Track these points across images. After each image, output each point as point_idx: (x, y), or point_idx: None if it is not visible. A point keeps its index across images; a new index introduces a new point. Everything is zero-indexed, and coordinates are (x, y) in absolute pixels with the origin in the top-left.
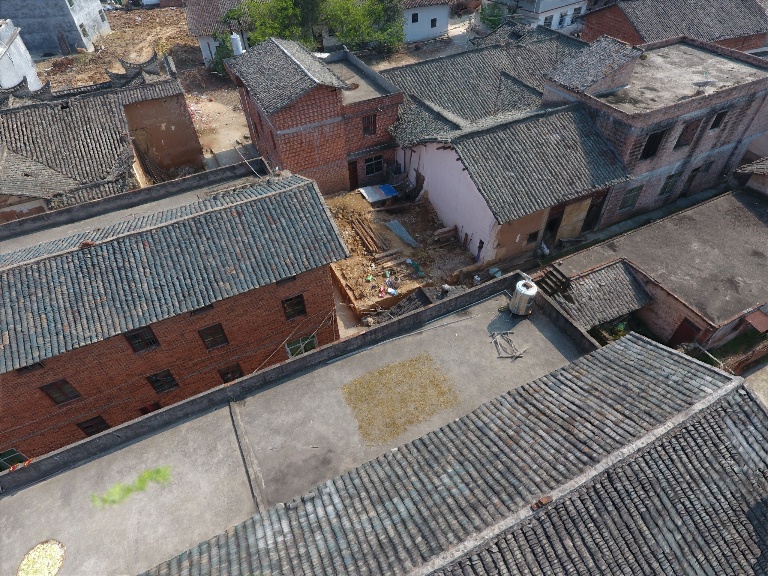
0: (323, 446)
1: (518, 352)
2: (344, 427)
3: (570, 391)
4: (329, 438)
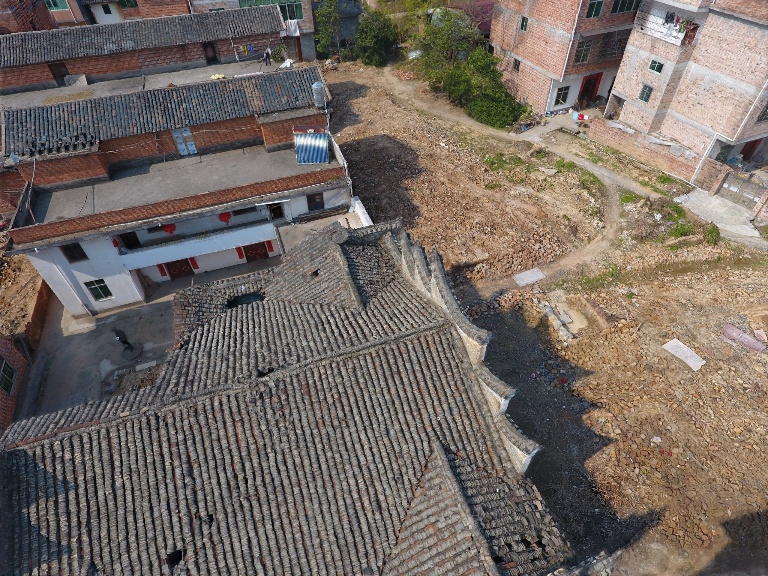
0: (112, 91)
1: (0, 104)
2: (100, 94)
3: (6, 57)
4: (108, 92)
